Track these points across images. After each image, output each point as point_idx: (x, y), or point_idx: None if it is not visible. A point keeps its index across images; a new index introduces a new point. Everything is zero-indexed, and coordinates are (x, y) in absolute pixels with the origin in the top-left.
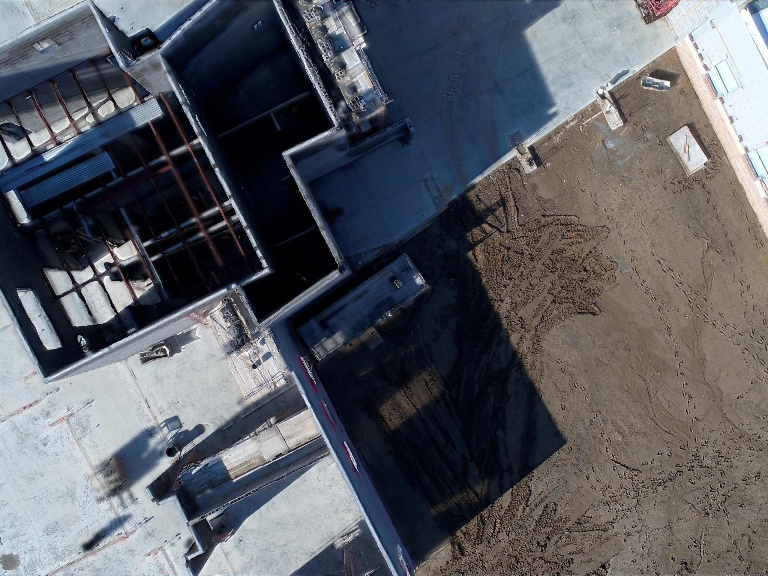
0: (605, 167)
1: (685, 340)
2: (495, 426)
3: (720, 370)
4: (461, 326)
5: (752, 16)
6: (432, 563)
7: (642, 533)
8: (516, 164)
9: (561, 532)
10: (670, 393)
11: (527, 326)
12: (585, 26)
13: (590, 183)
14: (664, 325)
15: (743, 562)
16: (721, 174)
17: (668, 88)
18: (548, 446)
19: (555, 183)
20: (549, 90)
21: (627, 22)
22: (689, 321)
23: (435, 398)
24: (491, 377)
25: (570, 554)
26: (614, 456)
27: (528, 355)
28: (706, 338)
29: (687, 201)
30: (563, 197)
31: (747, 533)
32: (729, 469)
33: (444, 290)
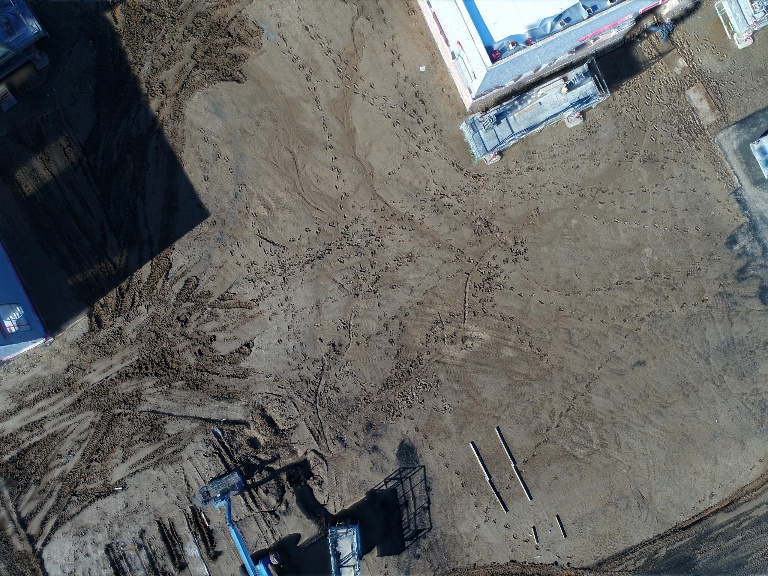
0: None
1: (334, 112)
2: (134, 195)
3: (371, 144)
4: (99, 90)
5: None
6: (68, 335)
7: (288, 312)
8: None
9: (203, 308)
10: (318, 167)
11: (169, 92)
12: None
13: None
14: (312, 95)
15: (394, 345)
16: None
17: None
18: (190, 218)
19: None
20: None
21: None
22: (339, 92)
23: (72, 165)
24: (130, 144)
25: (212, 331)
26: (260, 231)
27: (169, 122)
28: (356, 110)
29: None
30: None
31: (398, 316)
32: (380, 249)
33: (82, 52)
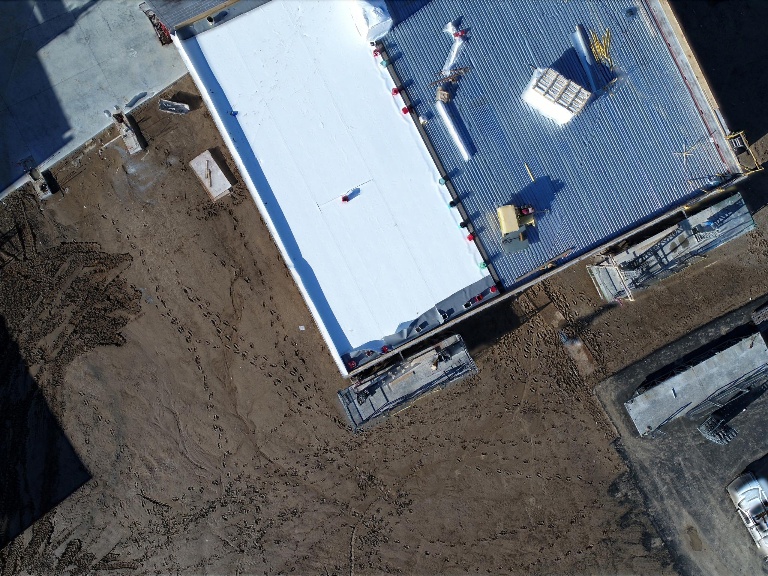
0: (126, 193)
1: (215, 371)
2: (15, 461)
3: (252, 402)
4: None
5: (185, 41)
6: None
7: (173, 571)
8: (31, 190)
9: (86, 570)
10: (200, 426)
11: (47, 357)
12: (100, 47)
13: (111, 209)
14: (193, 356)
15: None
16: (248, 200)
17: (188, 111)
18: (72, 481)
19: (75, 209)
20: (63, 113)
21: (144, 43)
22: (219, 352)
23: None
24: (9, 410)
25: None
26: (143, 491)
27: (48, 387)
28: (237, 369)
29: (213, 228)
30: (84, 224)
31: (284, 571)
32: (265, 505)
33: None
